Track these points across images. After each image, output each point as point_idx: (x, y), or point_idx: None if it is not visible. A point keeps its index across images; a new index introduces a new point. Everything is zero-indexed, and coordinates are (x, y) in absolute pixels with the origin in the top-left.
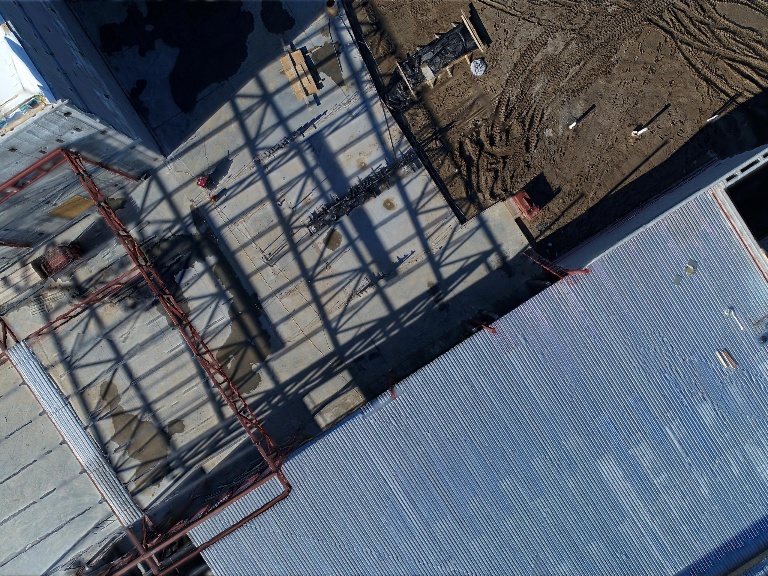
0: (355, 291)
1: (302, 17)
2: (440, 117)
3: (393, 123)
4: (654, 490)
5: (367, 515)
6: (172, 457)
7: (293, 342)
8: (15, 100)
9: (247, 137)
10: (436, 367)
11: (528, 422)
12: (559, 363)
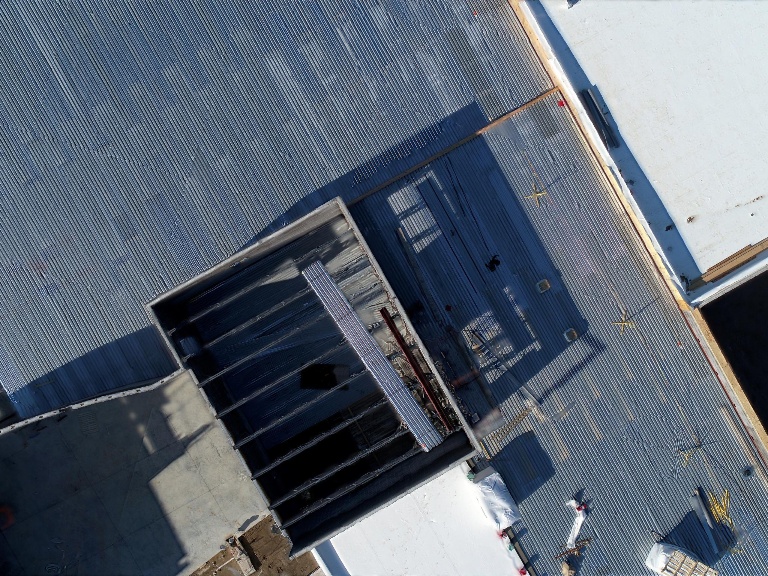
0: None
1: None
2: None
3: None
4: (321, 91)
5: (24, 92)
6: None
7: None
8: None
9: None
10: None
11: (196, 12)
12: None
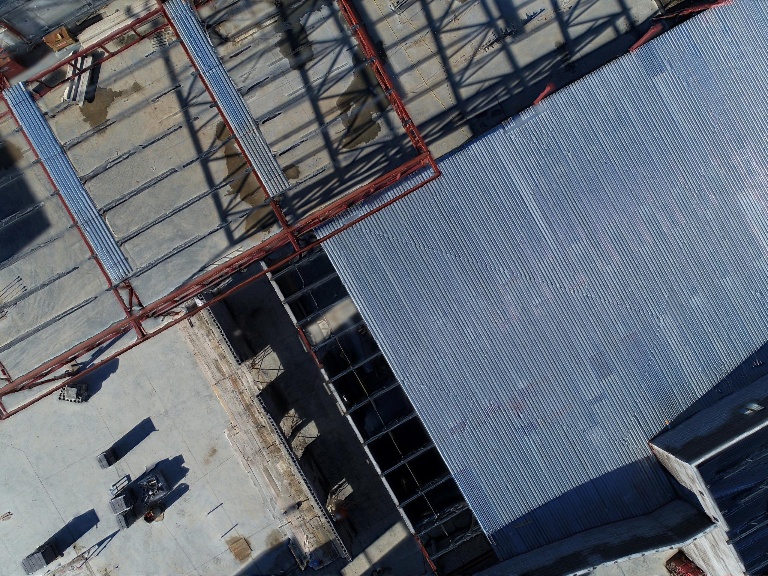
0: (481, 46)
1: None
2: None
3: None
4: None
5: (502, 232)
6: (285, 203)
7: (416, 93)
8: None
9: None
10: (580, 87)
11: (669, 150)
12: (703, 92)
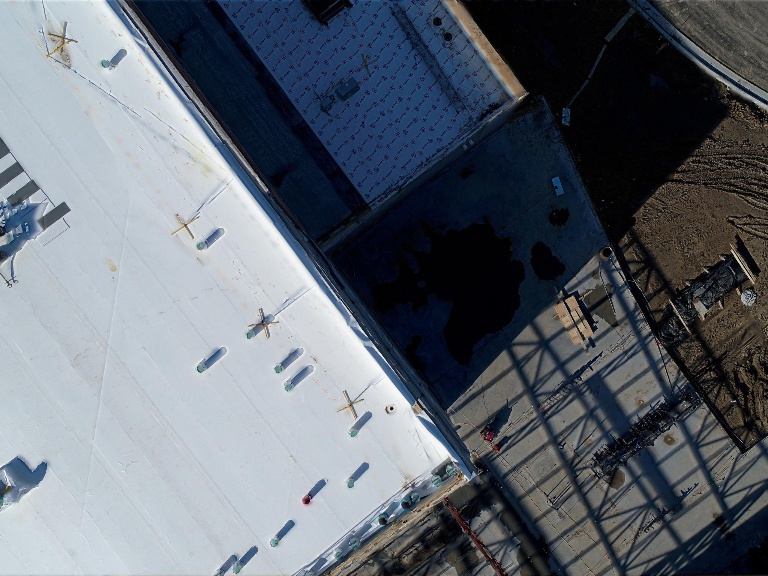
0: (641, 528)
1: (572, 262)
2: (713, 348)
3: (669, 359)
4: None
5: None
6: None
7: None
8: (420, 468)
9: (524, 384)
10: None
11: None
12: None
